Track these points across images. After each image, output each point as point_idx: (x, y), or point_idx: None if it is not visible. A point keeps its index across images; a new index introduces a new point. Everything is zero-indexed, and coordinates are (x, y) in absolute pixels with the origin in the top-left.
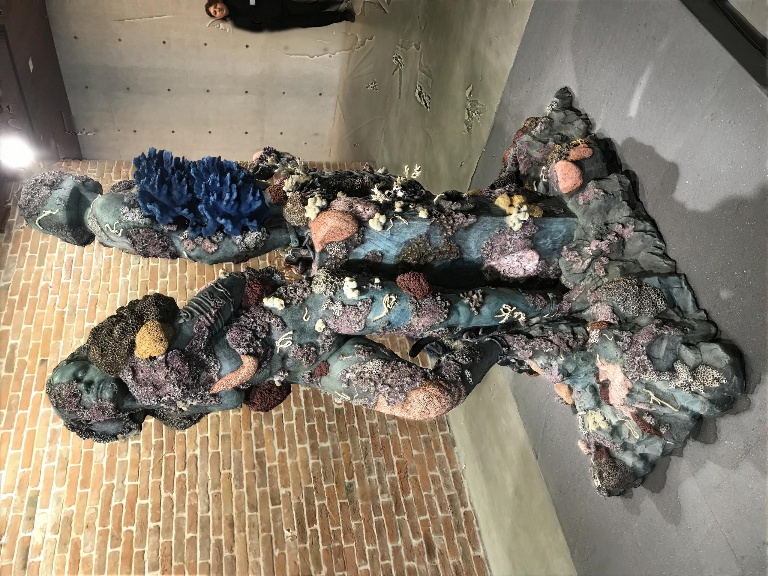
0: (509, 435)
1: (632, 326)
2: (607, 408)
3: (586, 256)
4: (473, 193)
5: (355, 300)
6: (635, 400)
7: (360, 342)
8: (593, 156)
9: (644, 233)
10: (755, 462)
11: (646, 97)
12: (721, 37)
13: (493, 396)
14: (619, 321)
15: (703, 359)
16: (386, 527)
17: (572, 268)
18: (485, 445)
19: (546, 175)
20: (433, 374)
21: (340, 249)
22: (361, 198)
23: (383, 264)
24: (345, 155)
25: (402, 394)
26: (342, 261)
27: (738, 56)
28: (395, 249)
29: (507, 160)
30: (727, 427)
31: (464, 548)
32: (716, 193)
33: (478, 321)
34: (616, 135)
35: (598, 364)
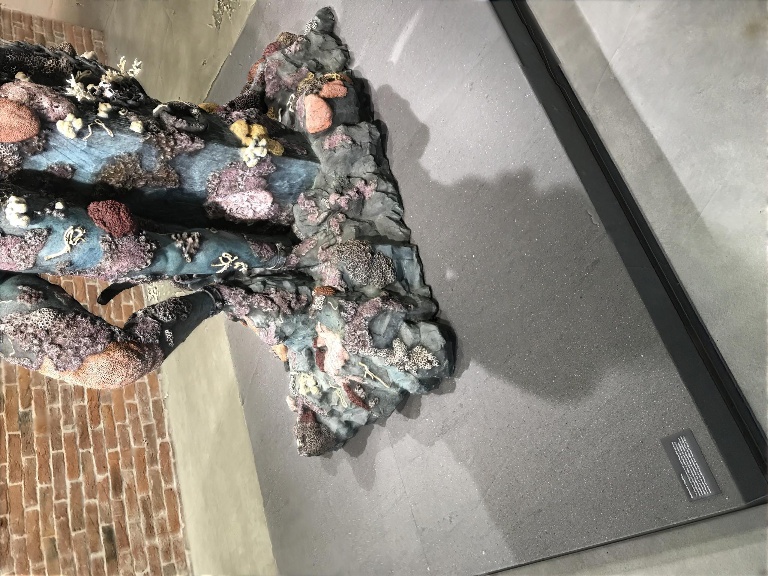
0: (218, 370)
1: (359, 296)
2: (320, 373)
3: (323, 208)
4: (208, 107)
5: (22, 229)
6: (349, 373)
7: (27, 282)
8: (347, 97)
9: (385, 195)
10: (450, 443)
11: (411, 44)
12: (495, 1)
13: (207, 327)
14: (346, 289)
15: (421, 340)
16: (66, 462)
17: (306, 219)
18: (192, 377)
19: (294, 106)
20: (122, 334)
21: (9, 153)
22: (50, 88)
23: (74, 181)
24: (64, 14)
25: (76, 359)
26: (12, 169)
27: (508, 27)
28: (92, 165)
29: (253, 75)
30: (431, 405)
31: (155, 481)
32: (461, 169)
33: (190, 269)
34: (374, 78)
35: (318, 330)
